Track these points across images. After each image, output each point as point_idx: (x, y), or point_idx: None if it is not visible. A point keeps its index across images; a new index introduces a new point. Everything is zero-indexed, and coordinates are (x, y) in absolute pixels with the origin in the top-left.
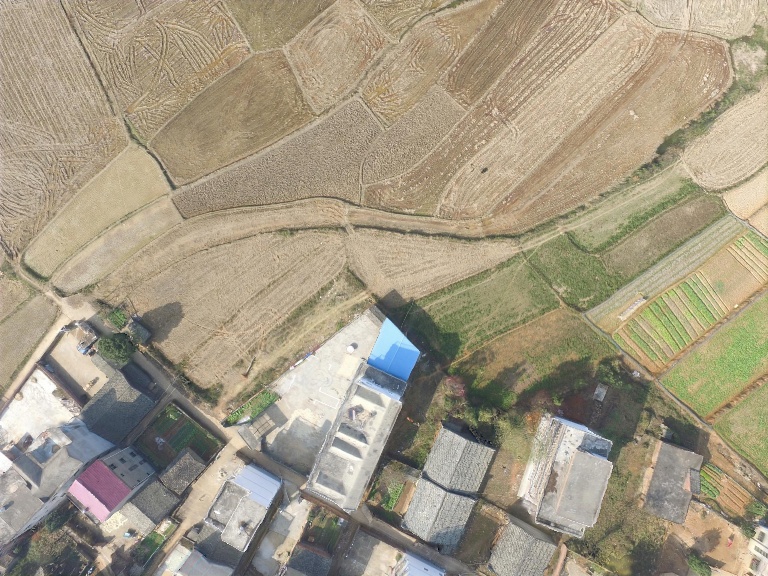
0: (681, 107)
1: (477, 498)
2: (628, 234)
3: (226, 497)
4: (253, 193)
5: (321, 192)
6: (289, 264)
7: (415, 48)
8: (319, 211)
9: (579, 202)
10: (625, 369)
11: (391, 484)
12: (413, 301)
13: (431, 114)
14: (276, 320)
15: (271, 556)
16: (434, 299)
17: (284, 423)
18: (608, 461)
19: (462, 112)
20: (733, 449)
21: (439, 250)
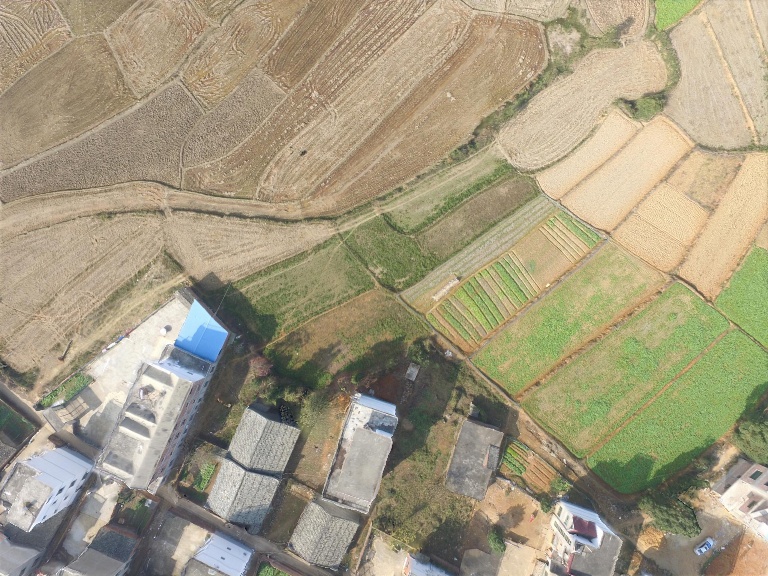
0: (497, 89)
1: (282, 477)
2: (442, 215)
3: (17, 478)
4: (73, 177)
5: (141, 176)
6: (107, 248)
7: (235, 32)
8: (138, 195)
9: (397, 184)
10: (436, 348)
11: (203, 465)
12: (230, 283)
13: (251, 97)
14: (93, 304)
15: (82, 538)
16: (251, 281)
17: (98, 406)
18: (387, 437)
19: (282, 95)
20: (540, 426)
21: (257, 232)
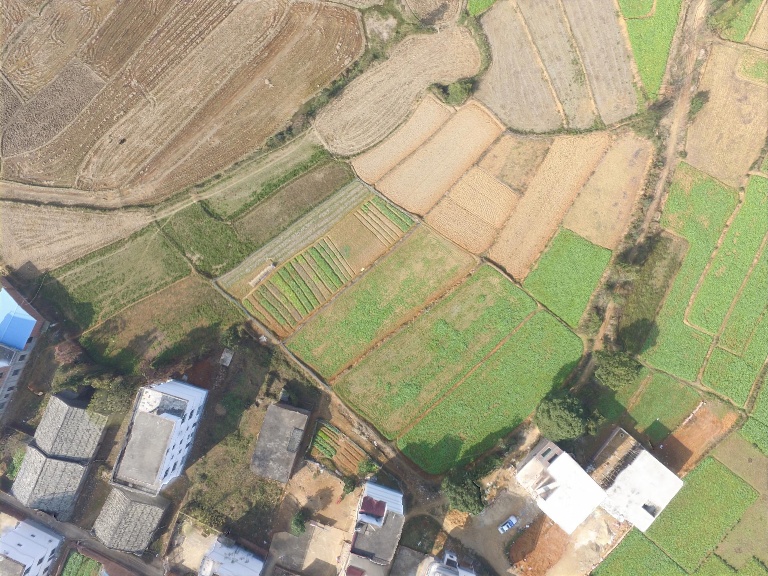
0: (315, 76)
1: (87, 464)
2: (259, 201)
3: None
4: None
5: None
6: None
7: (54, 21)
8: None
9: (215, 171)
10: (250, 334)
11: (16, 454)
12: (47, 272)
13: (71, 86)
14: None
15: None
16: (68, 270)
17: None
18: (170, 420)
19: (102, 84)
20: (351, 409)
21: (74, 221)
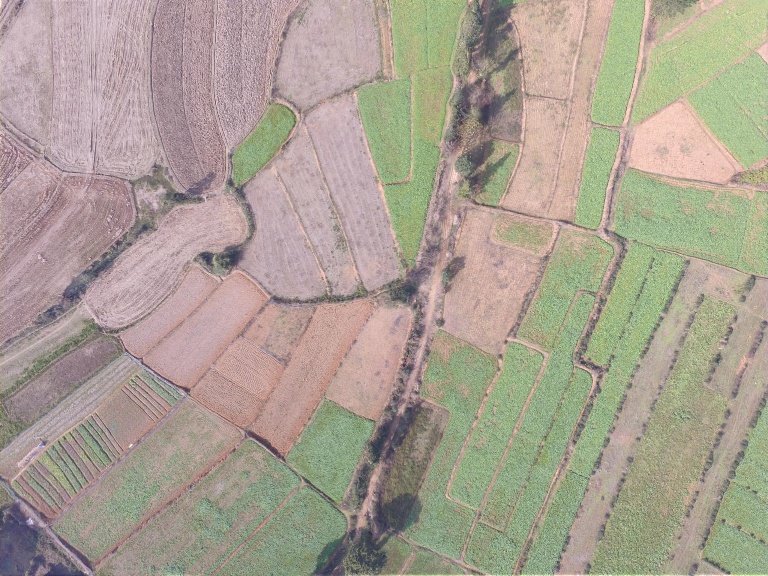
0: (87, 248)
1: None
2: (28, 379)
3: None
4: None
5: None
6: None
7: None
8: None
9: None
10: (15, 518)
11: None
12: None
13: None
14: None
15: None
16: None
17: None
18: None
19: None
20: None
21: None
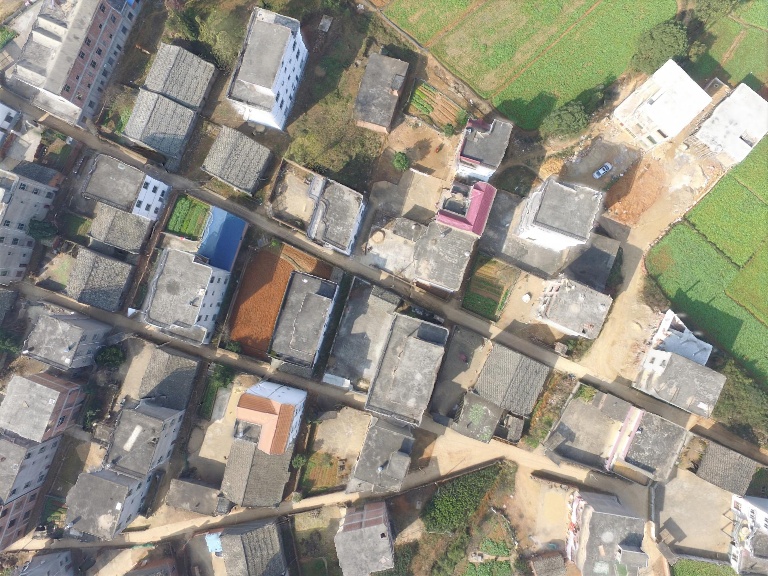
0: None
1: (196, 110)
2: None
3: None
4: None
5: None
6: None
7: None
8: None
9: None
10: None
11: (124, 112)
12: None
13: None
14: None
15: None
16: None
17: None
18: (286, 27)
19: None
20: (448, 70)
21: None
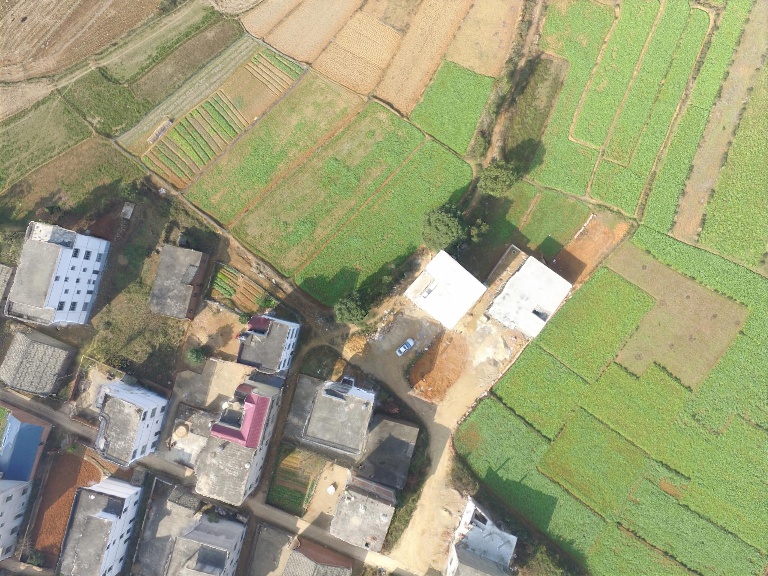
0: None
1: None
2: (153, 62)
3: None
4: None
5: None
6: None
7: None
8: None
9: (113, 39)
10: (148, 186)
11: None
12: None
13: None
14: None
15: None
16: None
17: None
18: (56, 245)
19: None
20: (249, 250)
21: None
